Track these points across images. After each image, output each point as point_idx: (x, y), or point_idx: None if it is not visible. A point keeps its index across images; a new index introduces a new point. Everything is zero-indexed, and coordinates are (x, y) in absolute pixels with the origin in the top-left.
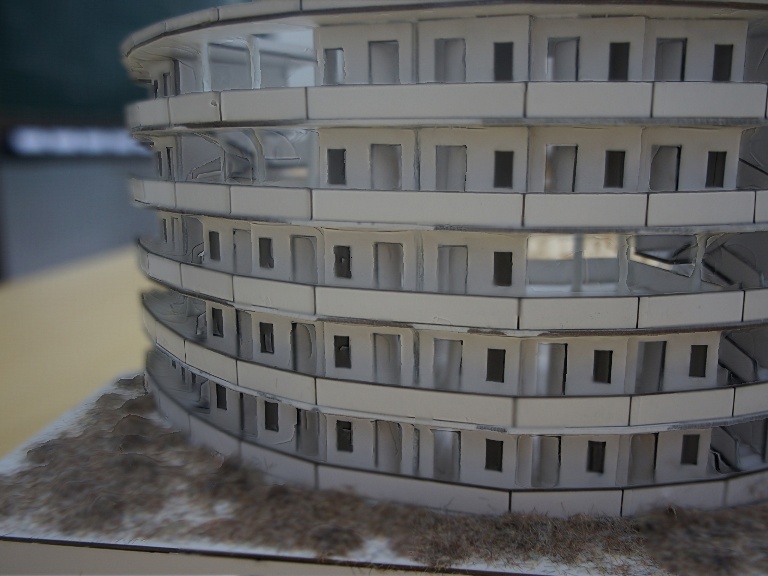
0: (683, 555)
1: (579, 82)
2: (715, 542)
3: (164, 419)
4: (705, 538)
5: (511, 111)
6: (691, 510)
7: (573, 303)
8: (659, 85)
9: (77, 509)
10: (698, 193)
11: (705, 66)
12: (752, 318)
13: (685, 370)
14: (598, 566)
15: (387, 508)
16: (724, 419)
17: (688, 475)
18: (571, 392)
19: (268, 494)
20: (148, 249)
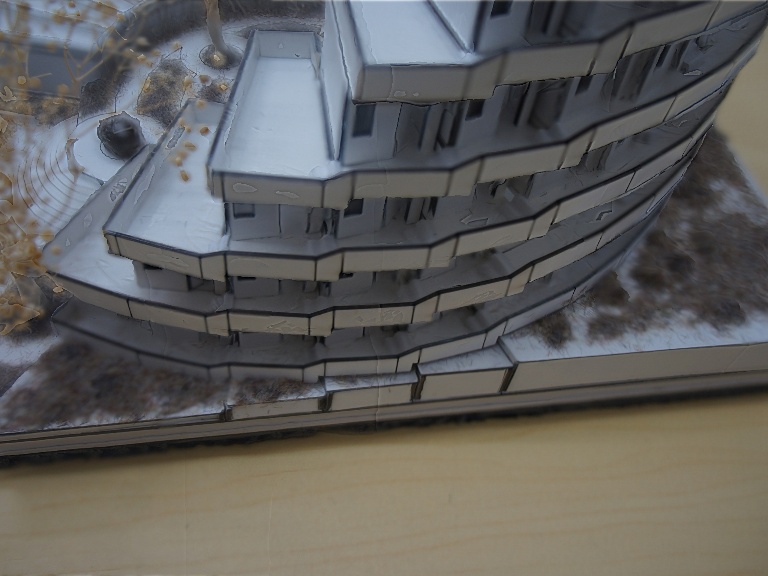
0: None
1: None
2: None
3: (626, 260)
4: None
5: None
6: None
7: None
8: None
9: None
10: None
11: None
12: None
13: None
14: None
15: None
16: None
17: None
18: None
19: None
20: (676, 143)
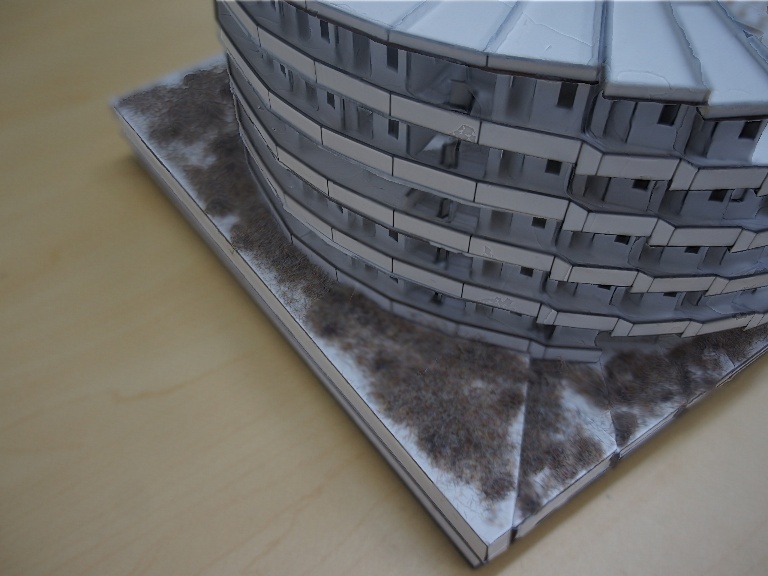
0: (321, 315)
1: (279, 40)
2: (352, 322)
3: None
4: (353, 317)
5: (256, 38)
6: (366, 301)
7: (297, 163)
8: (317, 64)
9: (164, 127)
10: (352, 141)
11: (381, 53)
12: (402, 228)
13: (387, 231)
14: (285, 292)
15: (256, 205)
16: (386, 271)
17: (387, 285)
18: (329, 205)
19: (226, 165)
20: None
